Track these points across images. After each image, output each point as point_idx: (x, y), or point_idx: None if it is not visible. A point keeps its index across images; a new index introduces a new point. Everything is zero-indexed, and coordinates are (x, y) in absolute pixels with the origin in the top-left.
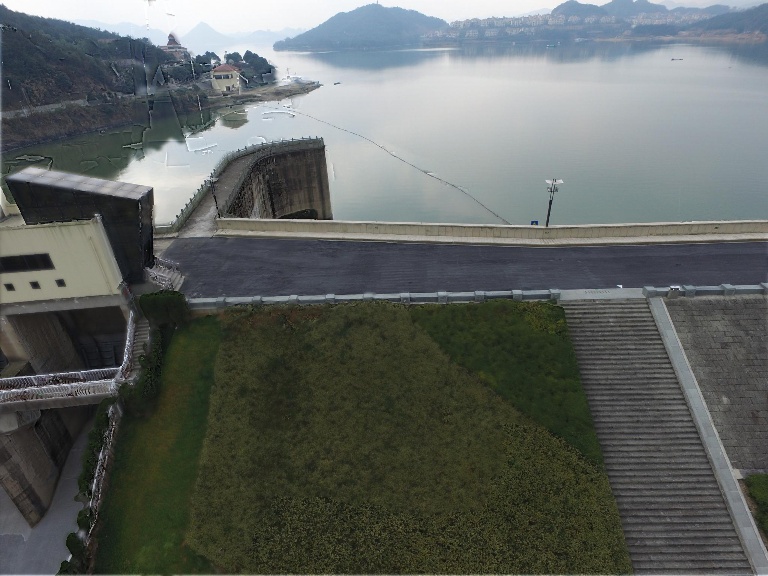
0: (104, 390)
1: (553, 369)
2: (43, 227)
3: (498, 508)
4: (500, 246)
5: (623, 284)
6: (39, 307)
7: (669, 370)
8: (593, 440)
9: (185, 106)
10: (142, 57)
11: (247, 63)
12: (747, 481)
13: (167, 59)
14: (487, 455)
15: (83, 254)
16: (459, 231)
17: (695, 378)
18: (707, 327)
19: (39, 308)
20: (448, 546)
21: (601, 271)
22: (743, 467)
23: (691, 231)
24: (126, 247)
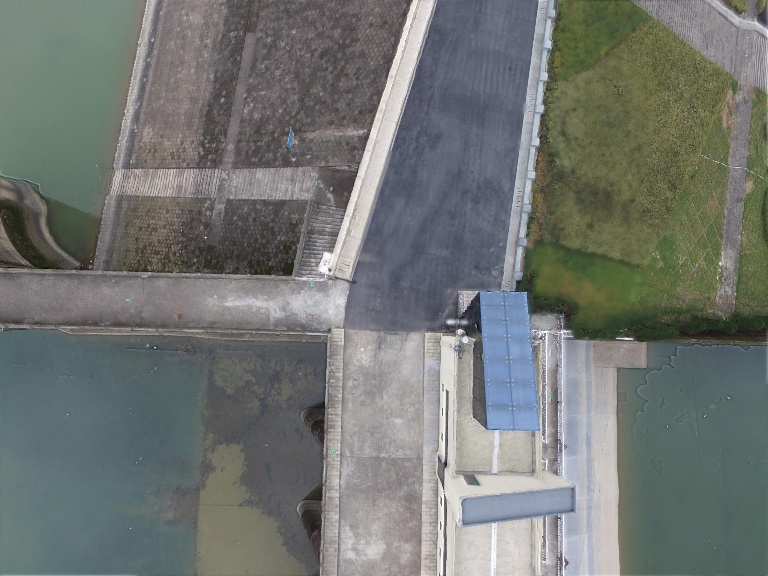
0: None
1: (606, 2)
2: None
3: None
4: None
5: None
6: None
7: None
8: (640, 10)
9: None
10: None
11: None
12: None
13: None
14: (638, 78)
15: None
16: None
17: None
18: None
19: None
20: None
21: None
22: None
23: None
24: None
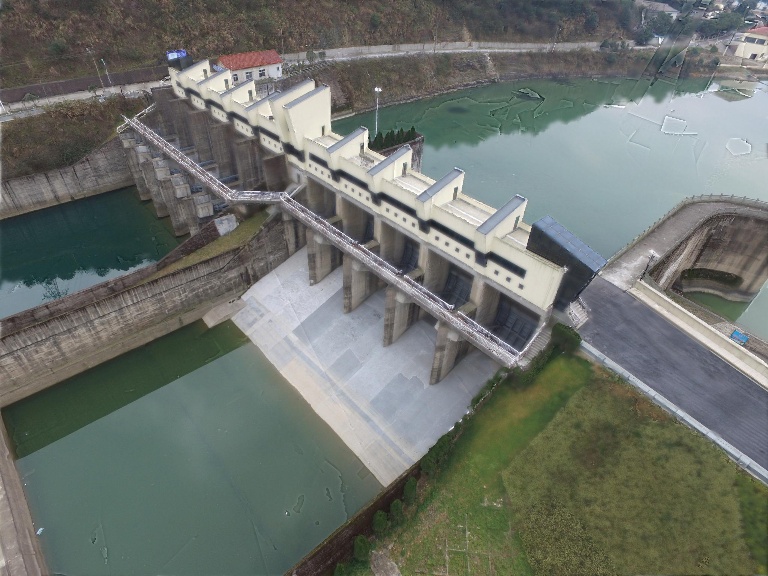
0: (506, 360)
1: None
2: (534, 258)
3: None
4: None
5: None
6: (502, 289)
7: None
8: None
9: (688, 70)
10: (676, 38)
11: None
12: None
13: None
14: None
15: (543, 282)
16: None
17: None
18: None
19: (501, 289)
20: None
21: None
22: None
23: None
24: (568, 289)
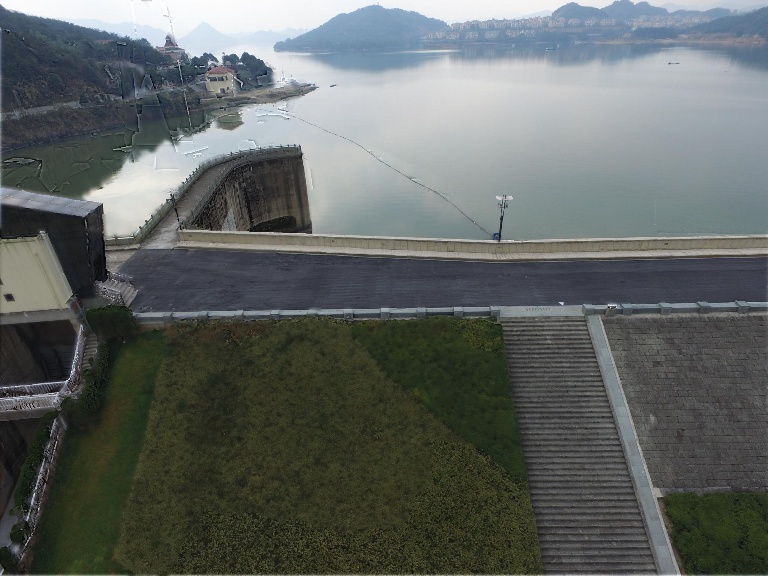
0: (49, 404)
1: (486, 387)
2: None
3: (420, 525)
4: (453, 260)
5: (565, 301)
6: None
7: (600, 388)
8: (518, 458)
9: (178, 108)
10: None
11: (243, 65)
12: (665, 500)
13: (163, 61)
14: (414, 472)
15: (30, 270)
16: (414, 245)
17: (625, 396)
18: (641, 345)
19: None
20: (368, 562)
21: (546, 287)
22: (664, 486)
23: (641, 247)
24: (75, 262)
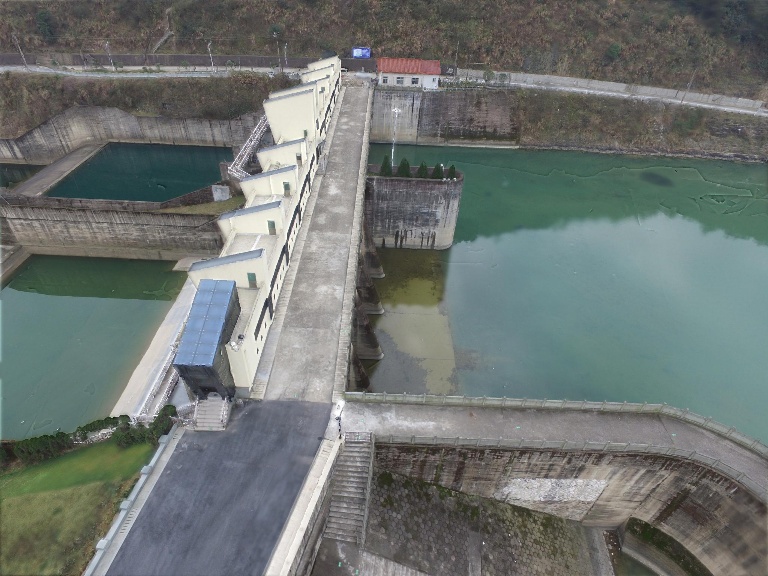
0: None
1: None
2: None
3: None
4: None
5: None
6: None
7: None
8: None
9: None
10: None
11: None
12: None
13: None
14: None
15: None
16: None
17: None
18: None
19: None
20: None
21: None
22: None
23: None
24: None
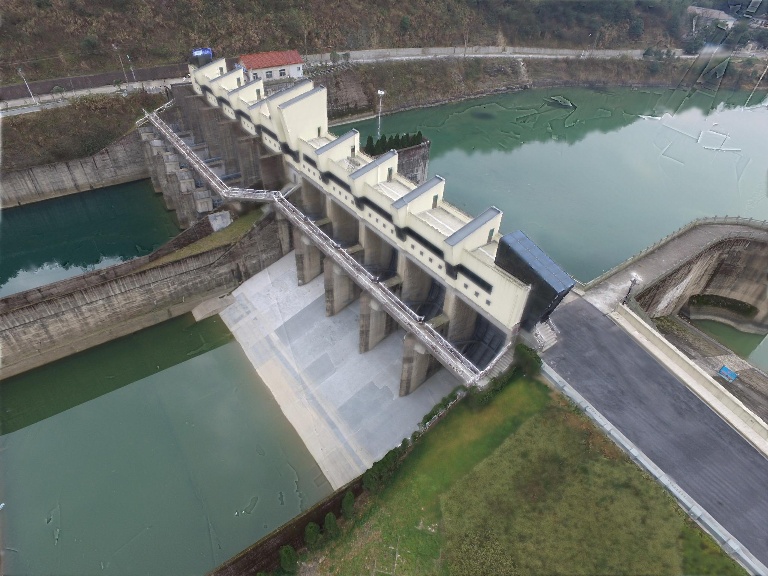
0: (466, 378)
1: None
2: (499, 274)
3: None
4: None
5: None
6: (471, 303)
7: None
8: None
9: (740, 81)
10: None
11: None
12: None
13: (767, 11)
14: None
15: (508, 299)
16: None
17: None
18: None
19: (471, 304)
20: None
21: None
22: None
23: None
24: (534, 309)
